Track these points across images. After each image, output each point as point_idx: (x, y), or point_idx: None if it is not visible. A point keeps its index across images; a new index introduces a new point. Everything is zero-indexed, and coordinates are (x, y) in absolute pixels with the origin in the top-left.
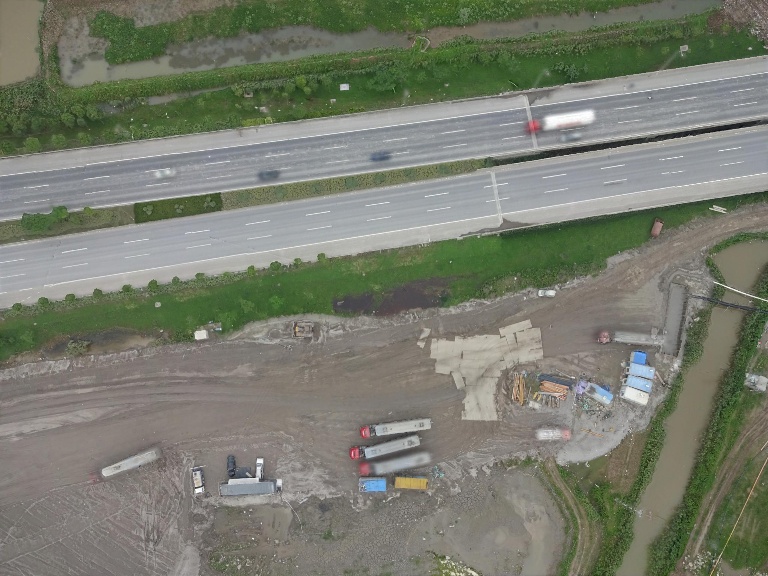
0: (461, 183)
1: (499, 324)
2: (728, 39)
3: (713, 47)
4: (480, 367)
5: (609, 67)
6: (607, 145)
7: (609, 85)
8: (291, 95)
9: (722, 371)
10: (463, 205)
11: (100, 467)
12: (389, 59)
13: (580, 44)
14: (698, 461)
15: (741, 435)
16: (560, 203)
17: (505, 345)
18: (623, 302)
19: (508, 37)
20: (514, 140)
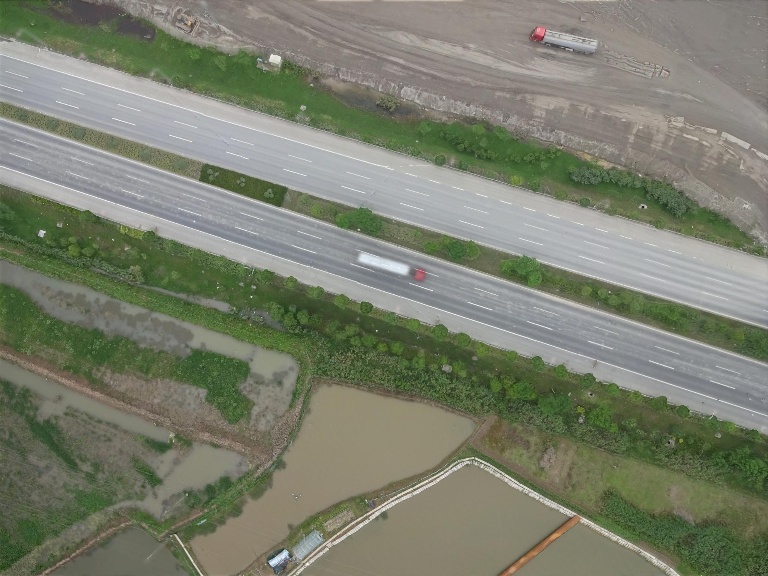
0: None
1: None
2: None
3: None
4: None
5: None
6: None
7: None
8: None
9: None
10: None
11: None
12: None
13: None
14: None
15: None
16: None
17: None
18: None
19: None
20: None
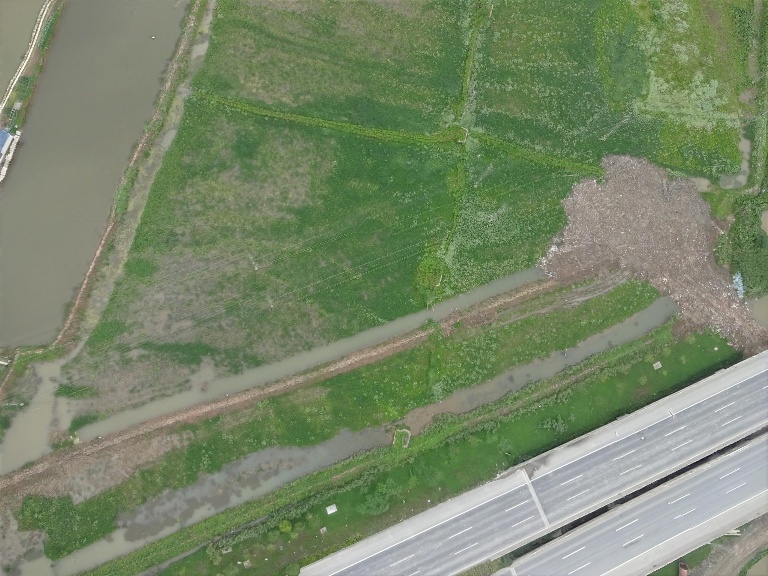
0: None
1: None
2: (694, 344)
3: None
4: None
5: (593, 407)
6: None
7: (601, 435)
8: None
9: None
10: None
11: None
12: (373, 466)
13: (561, 393)
14: None
15: None
16: None
17: None
18: None
19: (489, 406)
20: (524, 524)
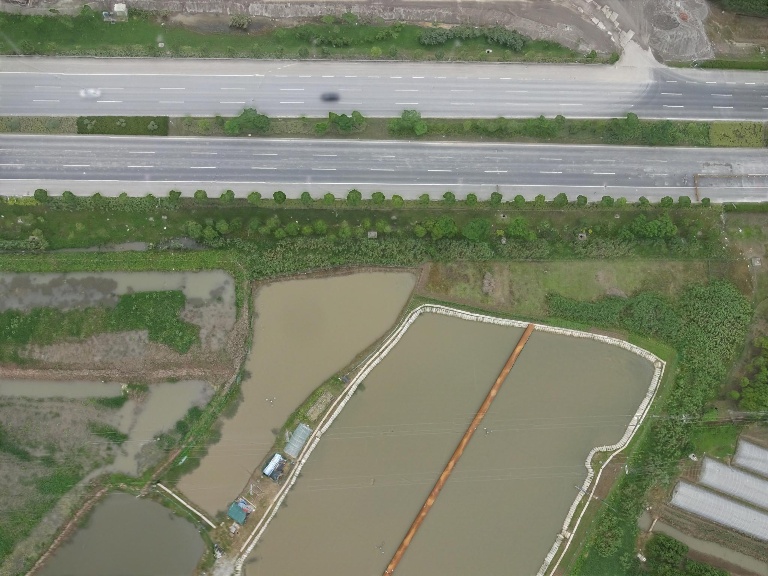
0: None
1: None
2: None
3: None
4: None
5: None
6: None
7: None
8: None
9: None
10: None
11: None
12: None
13: None
14: None
15: None
16: None
17: None
18: None
19: None
20: None
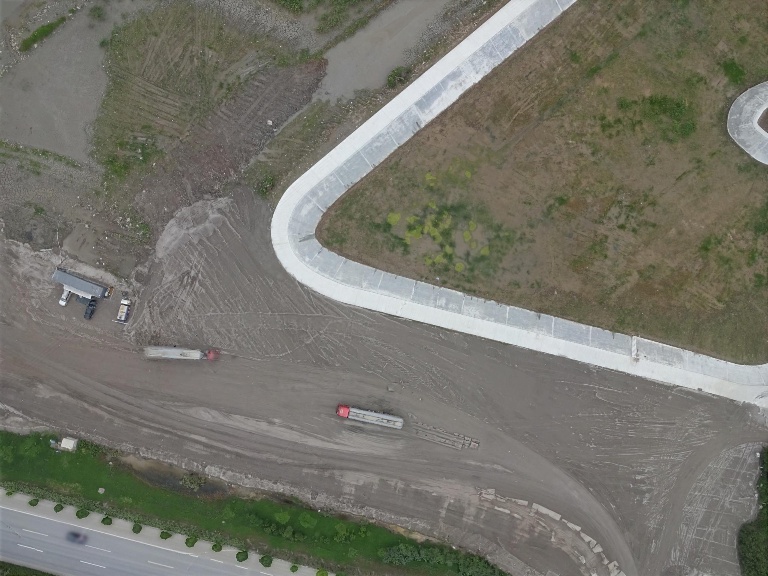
0: None
1: None
2: None
3: None
4: None
5: None
6: None
7: None
8: None
9: None
10: None
11: (210, 362)
12: None
13: None
14: None
15: None
16: None
17: None
18: None
19: None
20: None
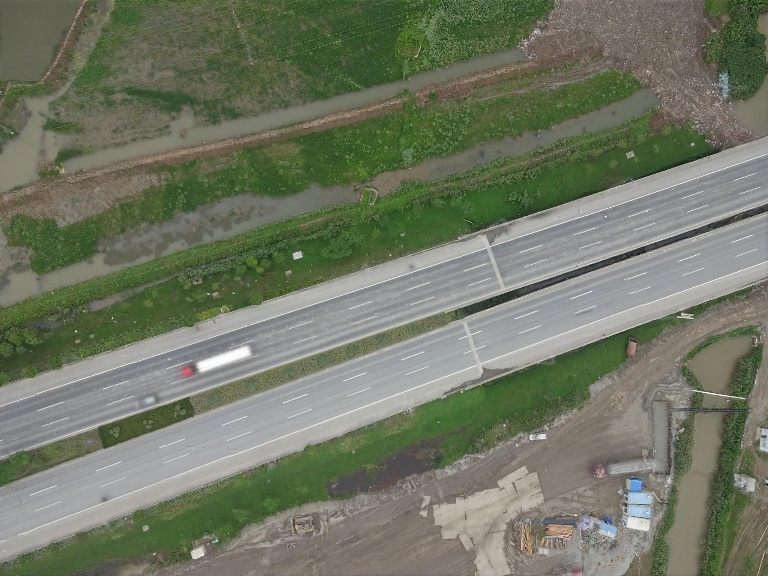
0: (435, 339)
1: (496, 477)
2: (670, 138)
3: (658, 151)
4: (485, 524)
5: (561, 187)
6: (572, 272)
7: (564, 210)
8: (243, 274)
9: (712, 475)
10: (441, 362)
11: None
12: (339, 219)
13: (529, 169)
14: (702, 568)
15: (738, 535)
16: (536, 342)
17: (506, 497)
18: (611, 429)
19: (456, 175)
20: (480, 284)
